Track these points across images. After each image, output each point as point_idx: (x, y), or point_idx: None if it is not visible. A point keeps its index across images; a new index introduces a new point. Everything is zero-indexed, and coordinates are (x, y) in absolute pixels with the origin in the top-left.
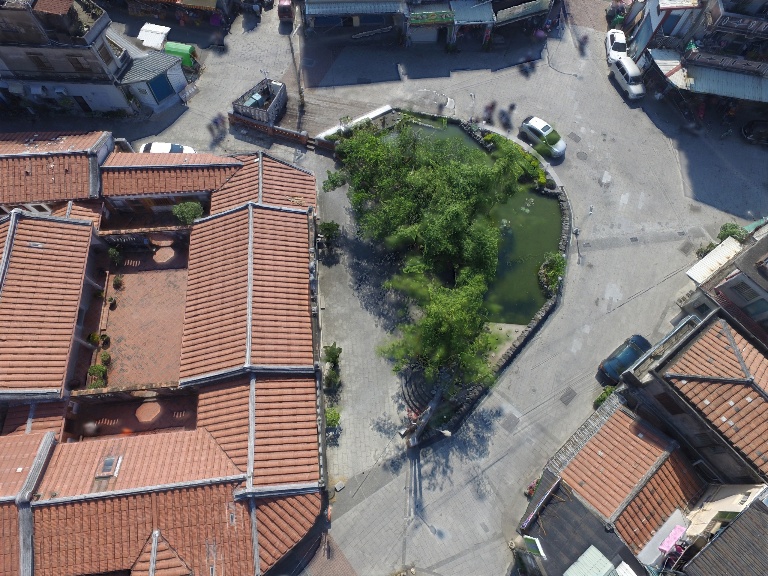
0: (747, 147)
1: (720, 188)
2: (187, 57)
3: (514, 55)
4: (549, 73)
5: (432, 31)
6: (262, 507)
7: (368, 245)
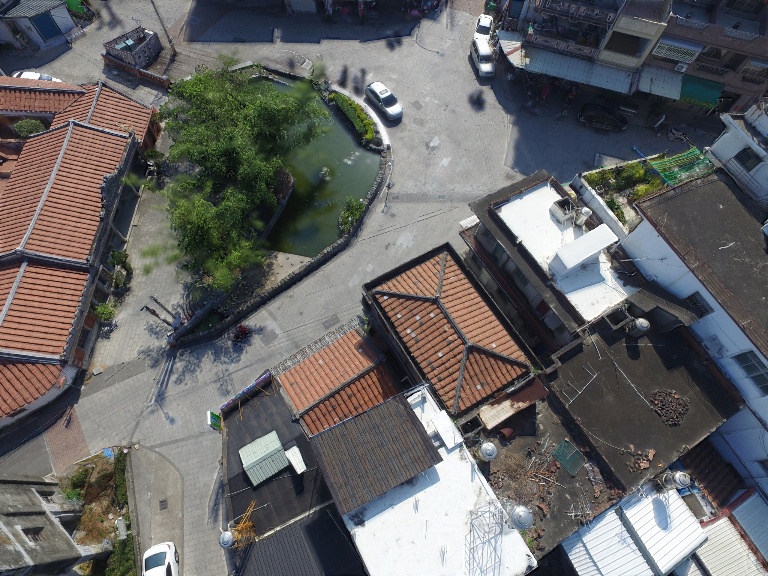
0: (580, 129)
1: (541, 161)
2: (78, 4)
3: (386, 30)
4: (413, 48)
5: (309, 1)
6: (0, 367)
7: (195, 178)
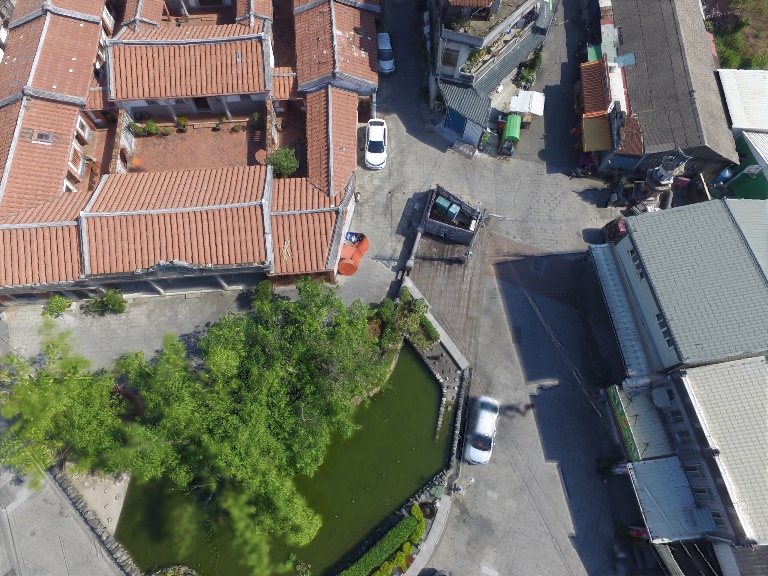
0: None
1: None
2: None
3: None
4: None
5: None
6: None
7: None
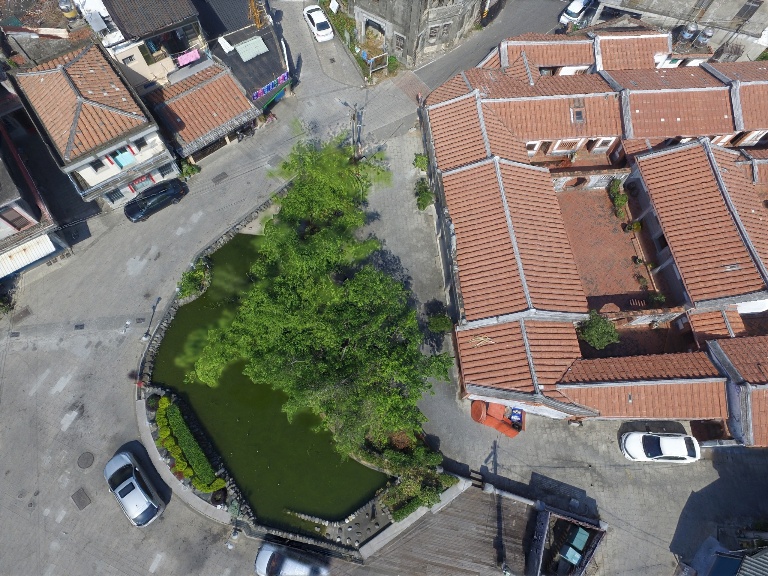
0: None
1: None
2: None
3: None
4: None
5: None
6: None
7: None
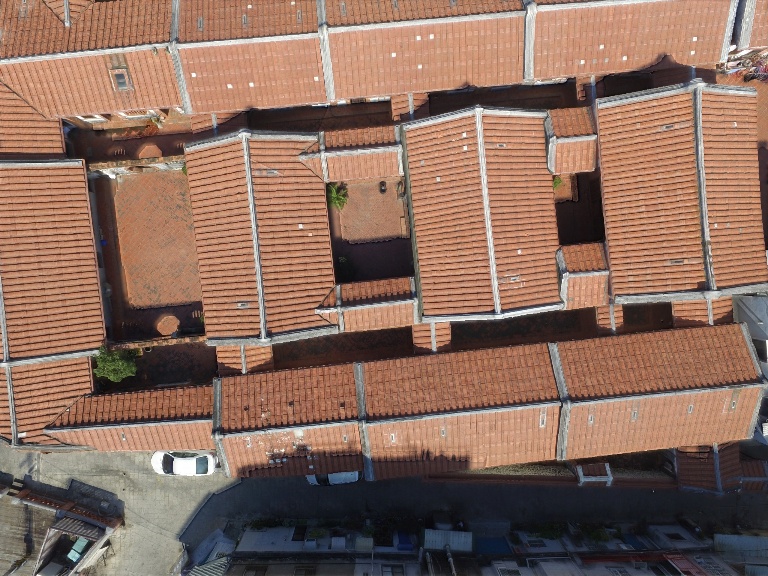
0: None
1: None
2: None
3: None
4: None
5: None
6: None
7: None
